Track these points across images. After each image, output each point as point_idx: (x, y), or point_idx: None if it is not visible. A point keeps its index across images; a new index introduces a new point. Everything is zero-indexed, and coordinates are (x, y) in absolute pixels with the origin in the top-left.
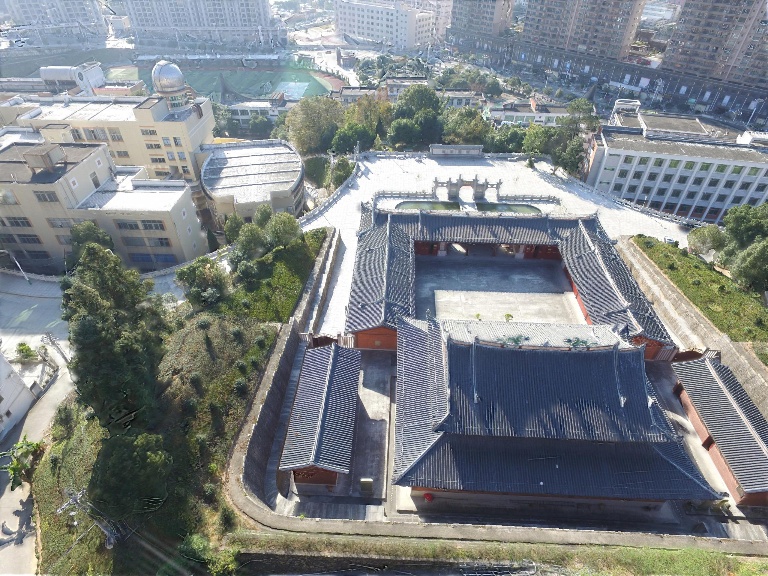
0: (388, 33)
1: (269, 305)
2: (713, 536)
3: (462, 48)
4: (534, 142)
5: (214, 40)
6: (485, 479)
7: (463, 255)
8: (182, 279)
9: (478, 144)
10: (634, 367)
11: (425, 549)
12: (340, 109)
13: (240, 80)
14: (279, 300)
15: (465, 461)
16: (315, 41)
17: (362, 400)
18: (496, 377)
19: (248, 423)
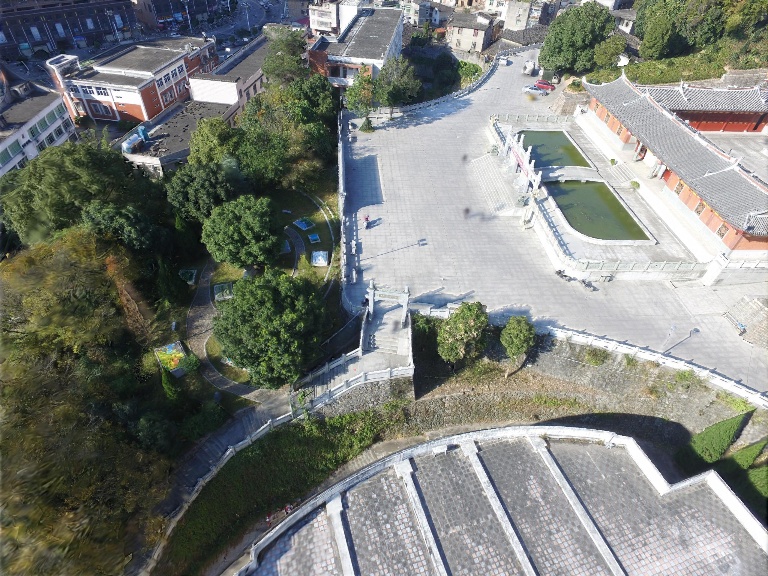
0: None
1: None
2: None
3: None
4: None
5: None
6: None
7: None
8: None
9: None
10: None
11: None
12: None
13: None
14: None
15: None
16: None
17: None
18: None
19: None
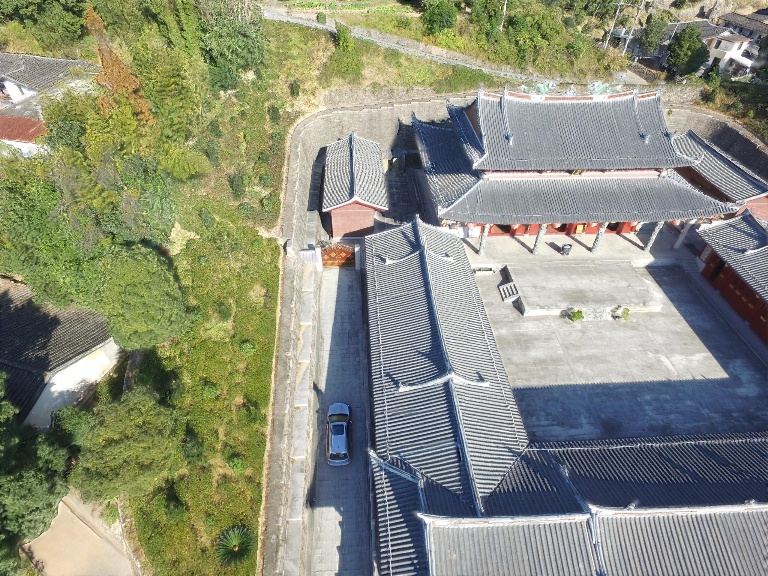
0: None
1: None
2: (402, 152)
3: None
4: None
5: None
6: None
7: None
8: None
9: None
10: None
11: None
12: None
13: None
14: None
15: None
16: None
17: None
18: None
19: (764, 146)
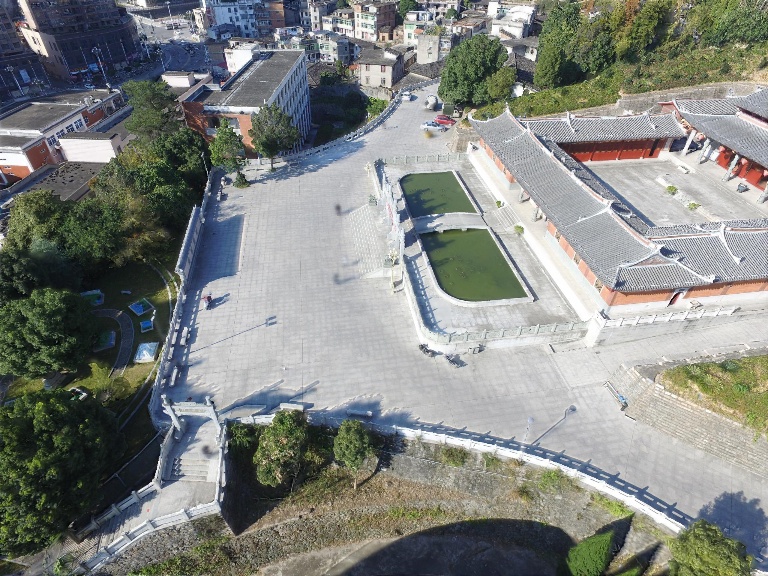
0: None
1: None
2: None
3: None
4: None
5: None
6: None
7: None
8: None
9: (159, 221)
10: None
11: None
12: None
13: None
14: None
15: None
16: None
17: None
18: None
19: None
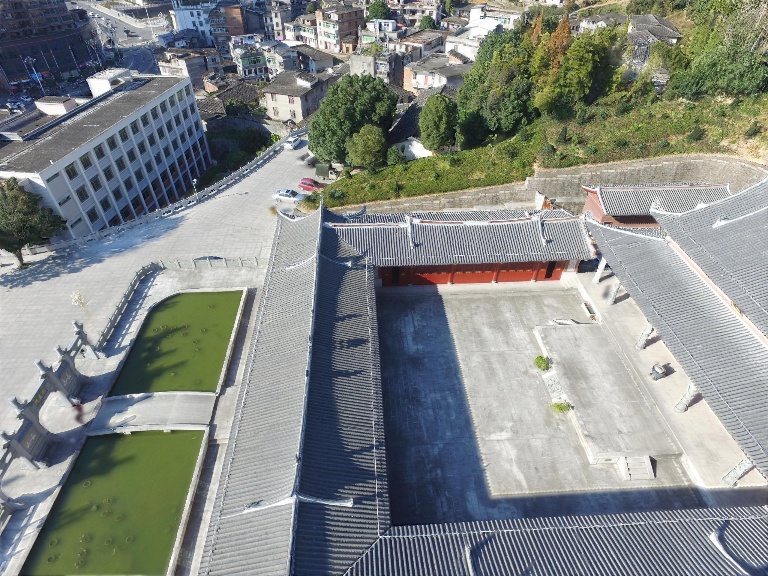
0: None
1: None
2: None
3: None
4: None
5: None
6: None
7: None
8: None
9: None
10: None
11: None
12: None
13: None
14: None
15: None
16: None
17: None
18: None
19: None
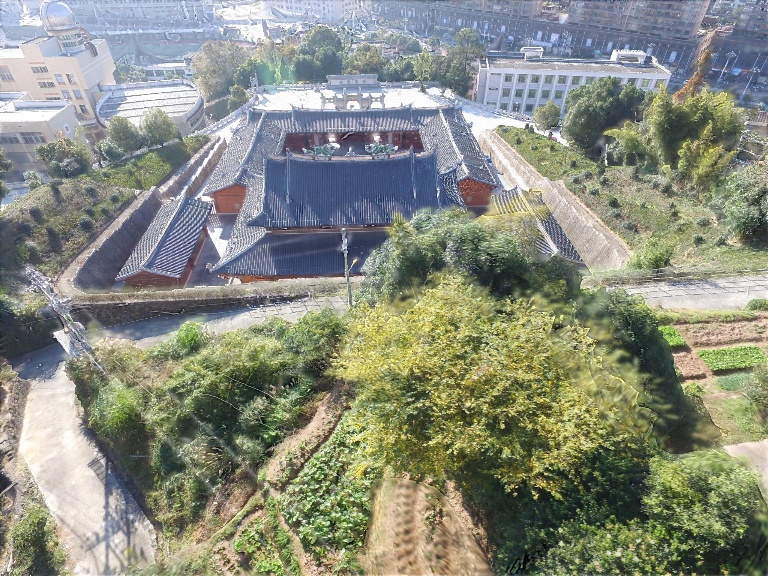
0: (315, 5)
1: (131, 177)
2: None
3: (387, 17)
4: (421, 65)
5: (137, 17)
6: (297, 266)
7: (338, 149)
8: (43, 156)
9: None
10: (428, 169)
11: (217, 292)
12: (245, 54)
13: (163, 52)
14: (143, 175)
15: (281, 255)
16: (243, 17)
17: (216, 247)
18: (307, 183)
19: (89, 249)
